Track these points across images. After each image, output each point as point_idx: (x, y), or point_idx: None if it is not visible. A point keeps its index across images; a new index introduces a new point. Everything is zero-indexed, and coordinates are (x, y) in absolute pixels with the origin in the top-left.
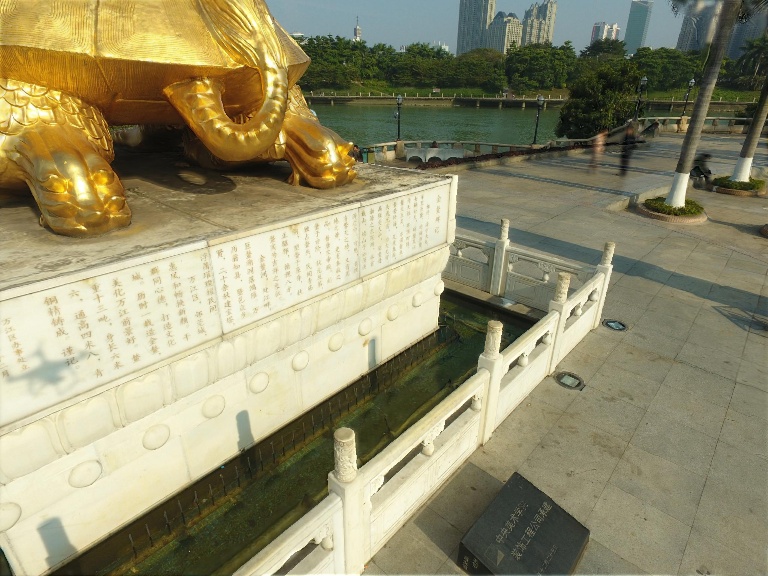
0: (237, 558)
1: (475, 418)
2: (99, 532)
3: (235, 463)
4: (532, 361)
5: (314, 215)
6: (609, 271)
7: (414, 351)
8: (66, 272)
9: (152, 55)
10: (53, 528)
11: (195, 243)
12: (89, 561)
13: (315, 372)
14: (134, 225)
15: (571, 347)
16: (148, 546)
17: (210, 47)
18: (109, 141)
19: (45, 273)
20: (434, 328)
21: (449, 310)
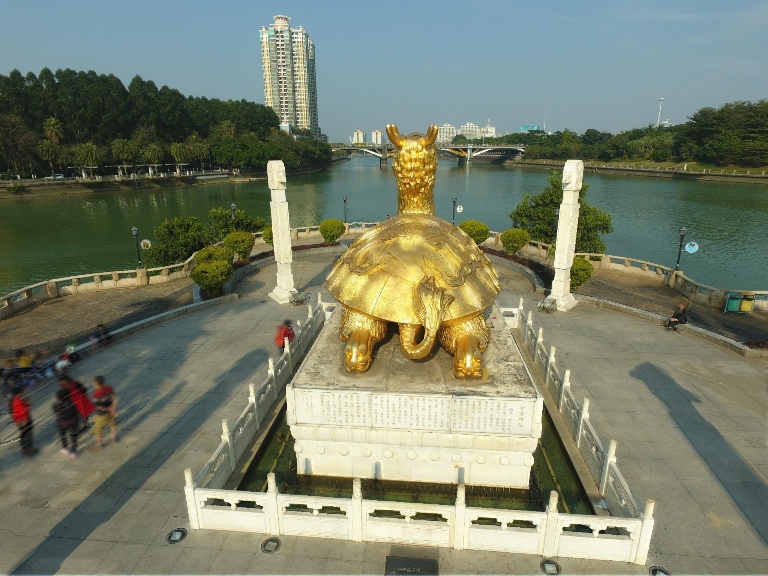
0: (344, 512)
1: (445, 528)
2: (320, 472)
3: (371, 481)
4: (512, 531)
5: (422, 395)
6: (646, 522)
7: (500, 492)
8: (329, 388)
9: (387, 317)
10: (309, 461)
11: (367, 392)
12: (315, 479)
13: (420, 465)
14: (367, 372)
15: (587, 556)
16: (329, 487)
17: (410, 315)
18: (380, 334)
19: (325, 386)
20: (524, 486)
21: (569, 485)
